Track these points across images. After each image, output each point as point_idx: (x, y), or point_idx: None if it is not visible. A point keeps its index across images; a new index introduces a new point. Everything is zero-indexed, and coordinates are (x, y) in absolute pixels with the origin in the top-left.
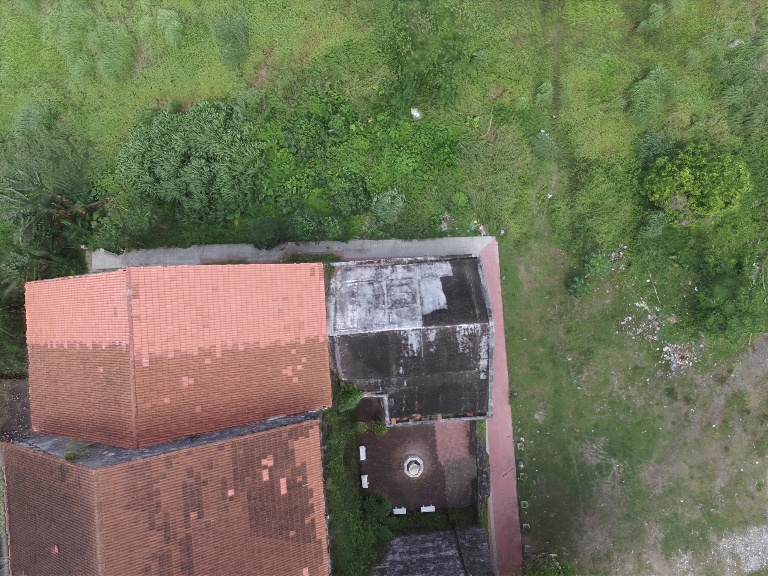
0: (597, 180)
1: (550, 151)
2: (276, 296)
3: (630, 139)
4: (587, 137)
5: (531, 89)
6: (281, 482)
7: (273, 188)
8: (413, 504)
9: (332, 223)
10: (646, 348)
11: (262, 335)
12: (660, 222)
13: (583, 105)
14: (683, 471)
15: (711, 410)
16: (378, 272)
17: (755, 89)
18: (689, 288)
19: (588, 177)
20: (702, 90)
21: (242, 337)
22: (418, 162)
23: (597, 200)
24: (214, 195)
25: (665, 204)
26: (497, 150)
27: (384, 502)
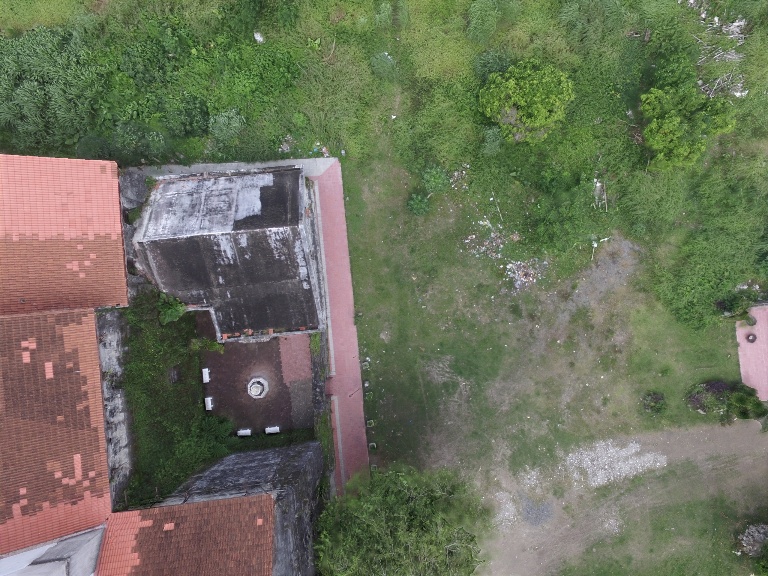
0: (438, 99)
1: (391, 72)
2: (59, 190)
3: (469, 58)
4: (428, 57)
5: (373, 12)
6: (46, 366)
7: (114, 113)
8: (259, 426)
9: (156, 138)
10: (490, 266)
11: (42, 228)
12: (496, 137)
13: (424, 26)
14: (529, 387)
15: (556, 326)
16: (200, 184)
17: (591, 6)
18: (532, 205)
19: (430, 97)
20: (542, 10)
21: (17, 228)
22: (257, 83)
23: (438, 119)
24: (50, 119)
25: (498, 118)
26: (337, 71)
27: (225, 422)
